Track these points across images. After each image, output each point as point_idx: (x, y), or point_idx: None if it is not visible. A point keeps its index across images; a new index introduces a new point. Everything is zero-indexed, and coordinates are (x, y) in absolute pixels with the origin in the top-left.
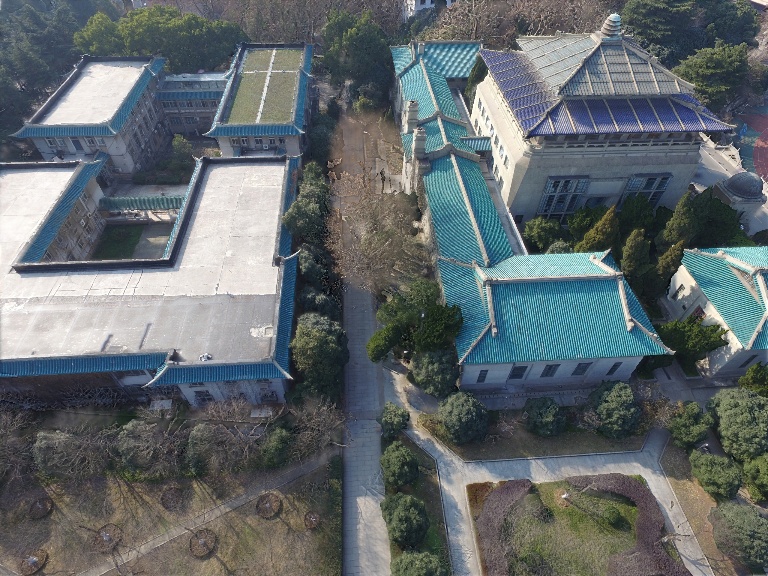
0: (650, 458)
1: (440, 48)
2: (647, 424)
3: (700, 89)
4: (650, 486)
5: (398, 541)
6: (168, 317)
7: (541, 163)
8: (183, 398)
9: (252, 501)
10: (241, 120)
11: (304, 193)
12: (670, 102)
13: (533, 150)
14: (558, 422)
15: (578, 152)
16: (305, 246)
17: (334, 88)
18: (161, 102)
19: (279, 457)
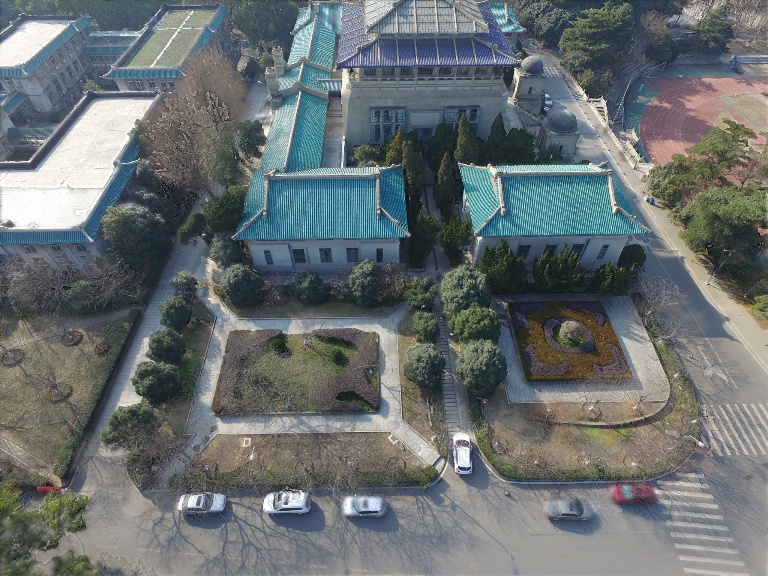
0: (391, 322)
1: (335, 8)
2: (384, 292)
3: (582, 47)
4: (381, 340)
5: (155, 359)
6: (16, 201)
7: (361, 94)
8: (28, 266)
9: (60, 335)
10: (138, 66)
11: (162, 119)
12: (472, 41)
13: (352, 83)
14: (316, 290)
15: (392, 85)
16: (150, 158)
17: (252, 48)
18: (89, 56)
19: (76, 298)
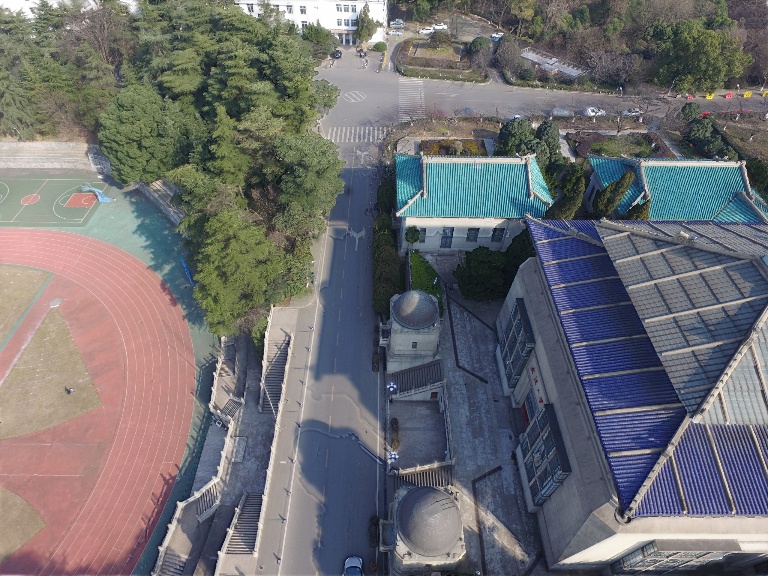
0: None
1: None
2: None
3: None
4: None
5: None
6: None
7: None
8: None
9: None
10: None
11: None
12: None
13: None
14: None
15: None
16: None
17: None
18: None
19: None
